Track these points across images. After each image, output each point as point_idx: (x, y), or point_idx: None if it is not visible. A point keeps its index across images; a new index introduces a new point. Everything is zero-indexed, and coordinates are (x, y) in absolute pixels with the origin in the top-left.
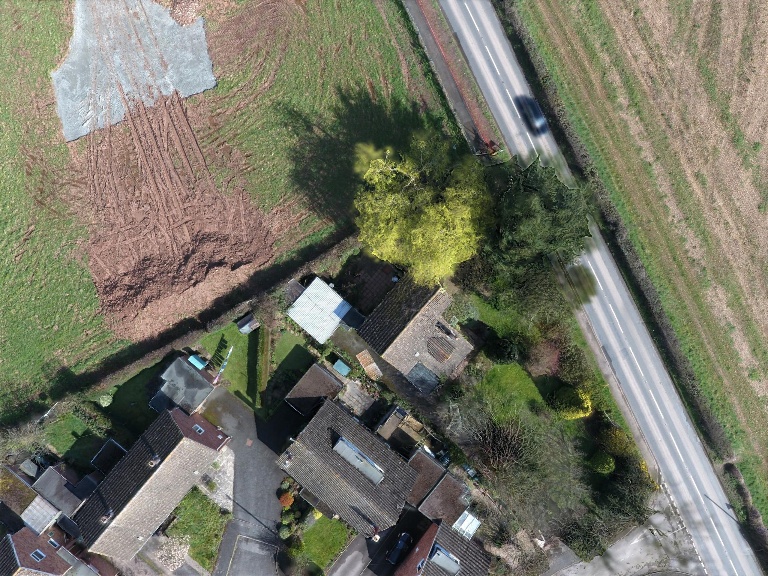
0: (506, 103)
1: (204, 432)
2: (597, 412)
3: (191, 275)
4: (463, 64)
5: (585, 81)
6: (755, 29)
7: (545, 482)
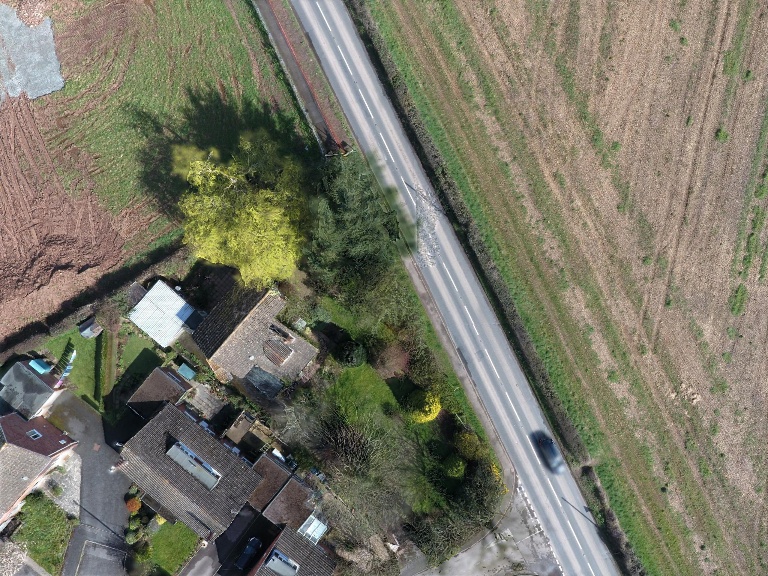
0: (359, 103)
1: (41, 437)
2: (451, 415)
3: (36, 278)
4: (315, 64)
5: (440, 81)
6: (614, 27)
7: (399, 486)
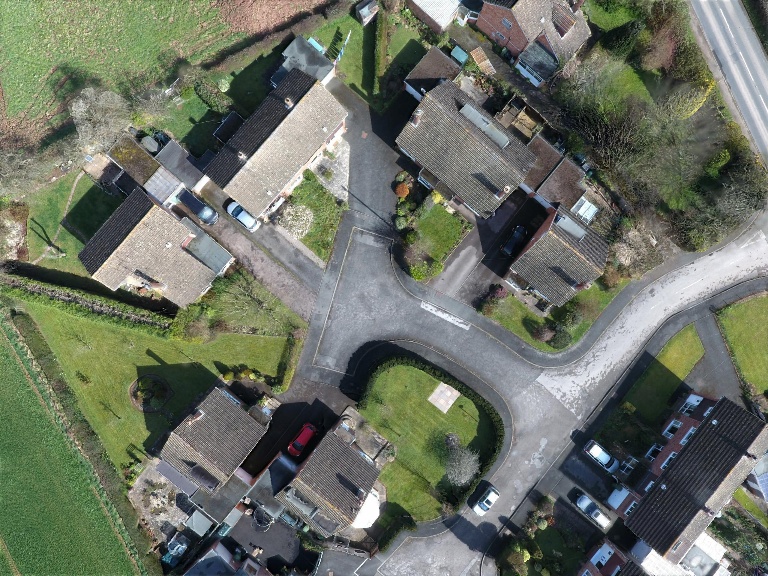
0: None
1: None
2: (708, 114)
3: None
4: None
5: None
6: None
7: (656, 183)
